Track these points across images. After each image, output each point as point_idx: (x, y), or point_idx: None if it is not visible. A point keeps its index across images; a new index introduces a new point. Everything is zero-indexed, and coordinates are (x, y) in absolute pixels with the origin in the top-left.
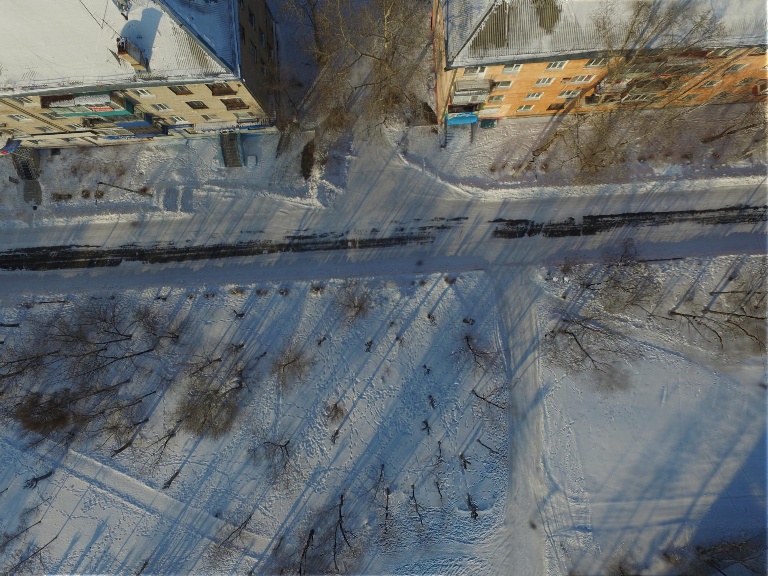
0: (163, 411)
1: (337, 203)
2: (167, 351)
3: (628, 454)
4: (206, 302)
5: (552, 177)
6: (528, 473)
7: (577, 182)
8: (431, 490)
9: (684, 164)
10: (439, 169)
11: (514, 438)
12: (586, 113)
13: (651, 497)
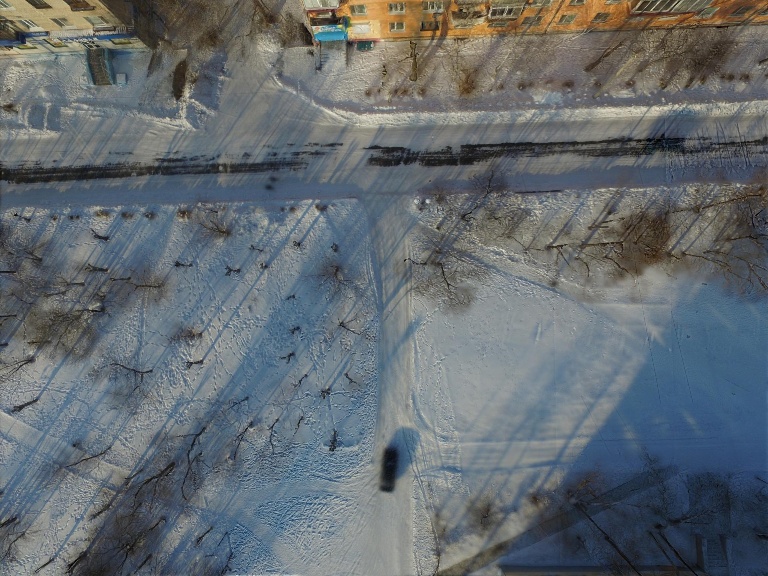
0: (23, 336)
1: (208, 125)
2: (29, 274)
3: (500, 392)
4: (70, 224)
5: (429, 103)
6: (397, 410)
7: (454, 109)
8: (296, 425)
9: (564, 92)
10: (314, 92)
11: (384, 373)
12: (466, 38)
13: (523, 438)
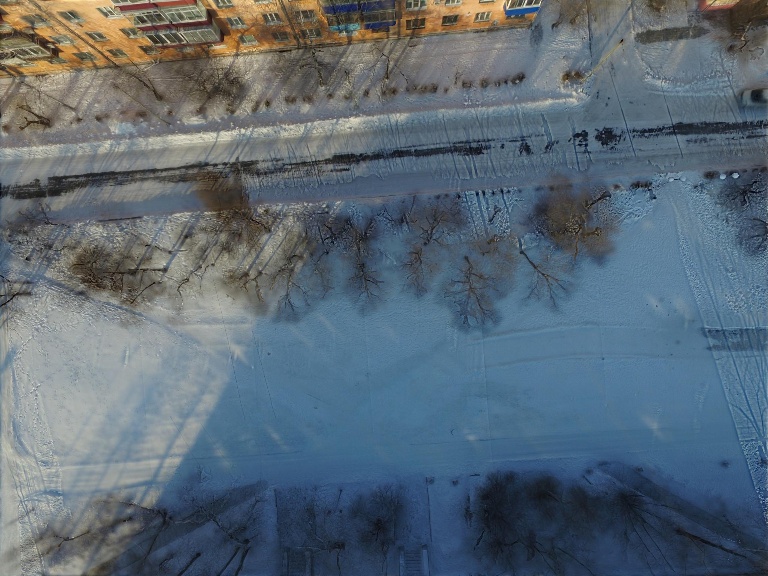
0: None
1: None
2: None
3: (93, 416)
4: None
5: (14, 138)
6: (0, 437)
7: (36, 143)
8: None
9: (137, 122)
10: None
11: None
12: (46, 74)
13: (119, 460)
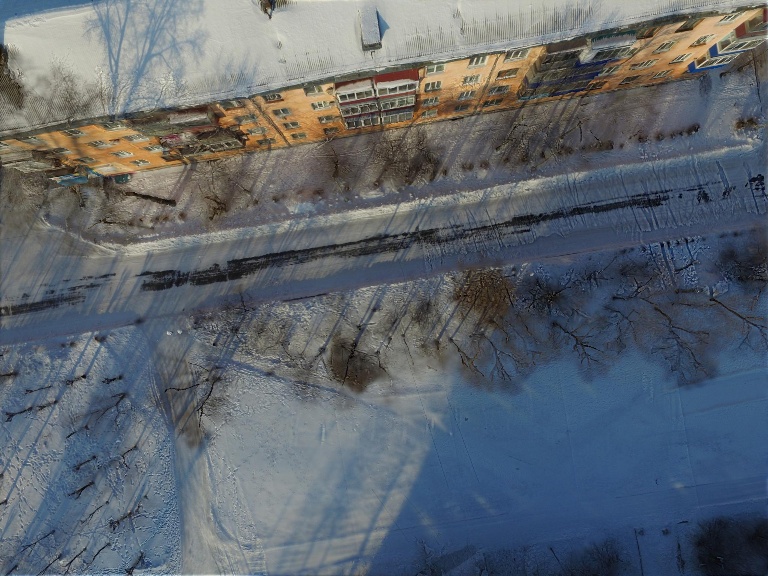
0: None
1: None
2: None
3: (294, 496)
4: None
5: (191, 225)
6: (200, 524)
7: (215, 228)
8: (104, 551)
9: (316, 200)
10: (82, 228)
11: (182, 490)
12: (218, 159)
13: (323, 537)
